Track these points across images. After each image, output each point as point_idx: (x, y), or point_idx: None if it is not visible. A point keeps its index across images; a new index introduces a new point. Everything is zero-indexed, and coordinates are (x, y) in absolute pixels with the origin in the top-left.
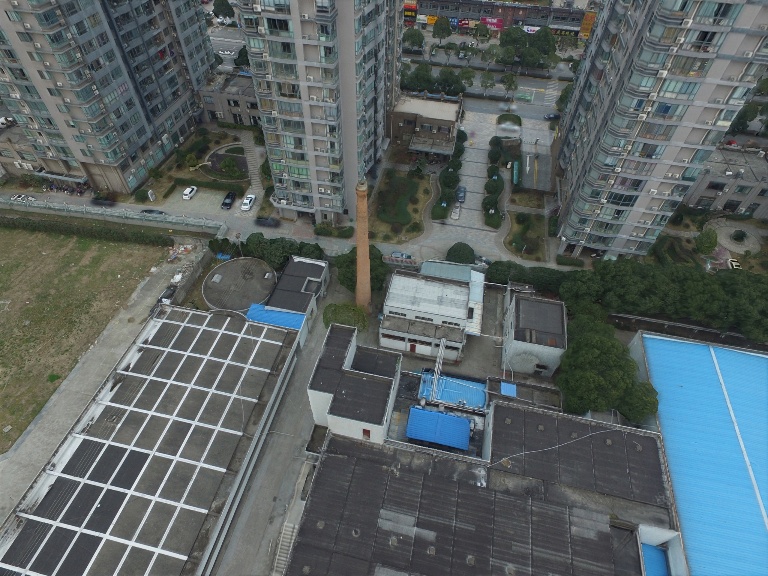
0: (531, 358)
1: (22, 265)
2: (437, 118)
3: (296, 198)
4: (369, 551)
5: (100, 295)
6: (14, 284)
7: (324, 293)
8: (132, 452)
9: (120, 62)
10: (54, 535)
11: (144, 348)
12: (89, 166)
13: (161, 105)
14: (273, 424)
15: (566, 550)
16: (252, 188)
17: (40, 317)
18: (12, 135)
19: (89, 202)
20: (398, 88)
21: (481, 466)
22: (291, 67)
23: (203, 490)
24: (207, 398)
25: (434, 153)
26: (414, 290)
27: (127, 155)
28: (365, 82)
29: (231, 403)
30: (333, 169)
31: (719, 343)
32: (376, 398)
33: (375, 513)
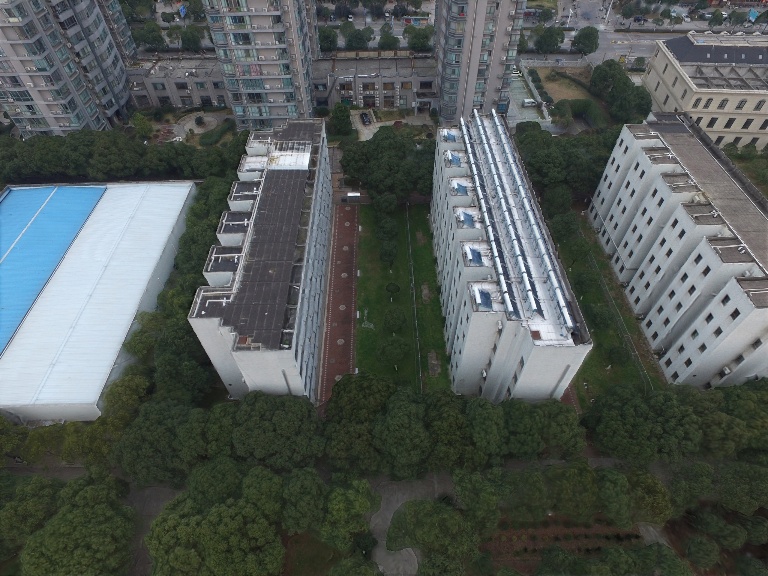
0: None
1: None
2: None
3: None
4: None
5: None
6: None
7: None
8: None
9: None
10: None
11: None
12: None
13: None
14: None
15: None
16: None
17: None
18: None
19: None
20: None
21: None
22: None
23: None
24: None
25: None
26: None
27: None
28: None
29: None
30: None
31: (64, 184)
32: None
33: None
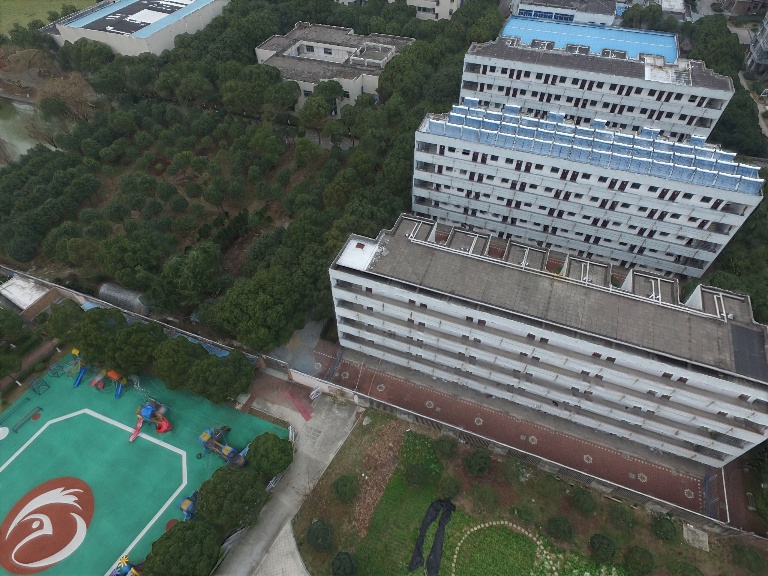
0: None
1: None
2: None
3: None
4: None
5: None
6: None
7: None
8: None
9: None
10: None
11: None
12: None
13: None
14: None
15: (566, 0)
16: None
17: None
18: None
19: None
20: None
21: None
22: None
23: None
24: None
25: None
26: (675, 1)
27: None
28: None
29: None
30: None
31: None
32: None
33: None
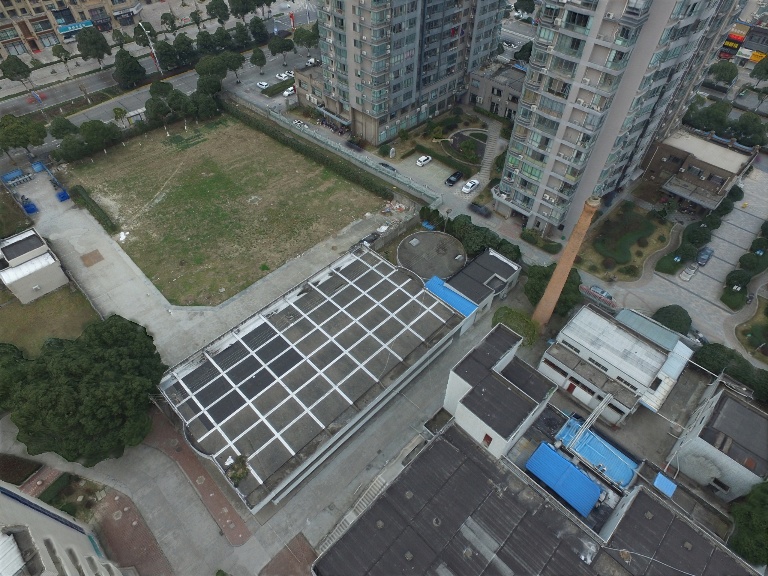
0: (711, 467)
1: (280, 175)
2: (713, 164)
3: (517, 196)
4: (441, 546)
5: (321, 219)
6: (269, 187)
7: (504, 295)
8: (292, 350)
9: (417, 30)
10: (218, 381)
11: (335, 274)
12: (356, 113)
13: (433, 77)
14: (406, 388)
15: None
16: (479, 174)
17: (275, 218)
18: (314, 73)
19: (344, 143)
20: (679, 119)
21: (594, 541)
22: (571, 65)
23: (329, 409)
24: (364, 337)
25: (691, 201)
26: (600, 331)
27: (388, 112)
28: (644, 101)
29: (380, 351)
30: (568, 179)
31: None
32: (512, 412)
33: (462, 516)
